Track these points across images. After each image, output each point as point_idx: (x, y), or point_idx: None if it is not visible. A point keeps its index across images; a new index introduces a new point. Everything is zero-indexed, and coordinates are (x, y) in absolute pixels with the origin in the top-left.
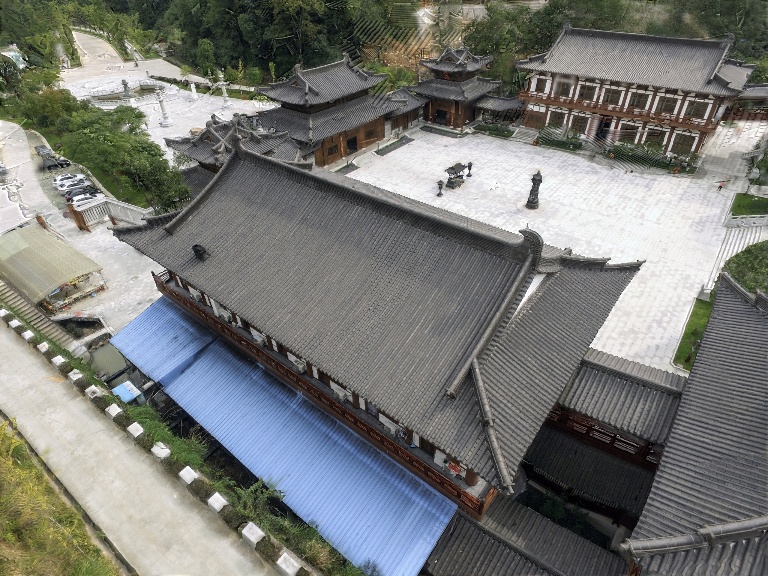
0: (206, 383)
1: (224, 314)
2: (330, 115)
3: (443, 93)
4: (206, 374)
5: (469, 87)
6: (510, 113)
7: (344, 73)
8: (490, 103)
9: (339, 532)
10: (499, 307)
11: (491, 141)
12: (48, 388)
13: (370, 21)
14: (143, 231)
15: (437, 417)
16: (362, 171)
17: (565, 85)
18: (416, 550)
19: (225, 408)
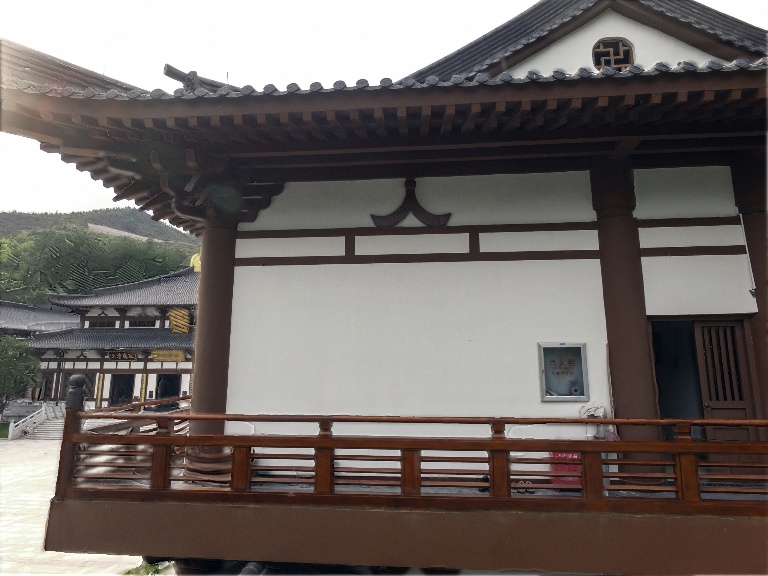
0: None
1: None
2: None
3: None
4: None
5: None
6: None
7: None
8: None
9: None
10: None
11: None
12: None
13: None
14: None
15: None
16: None
17: None
18: None
19: None
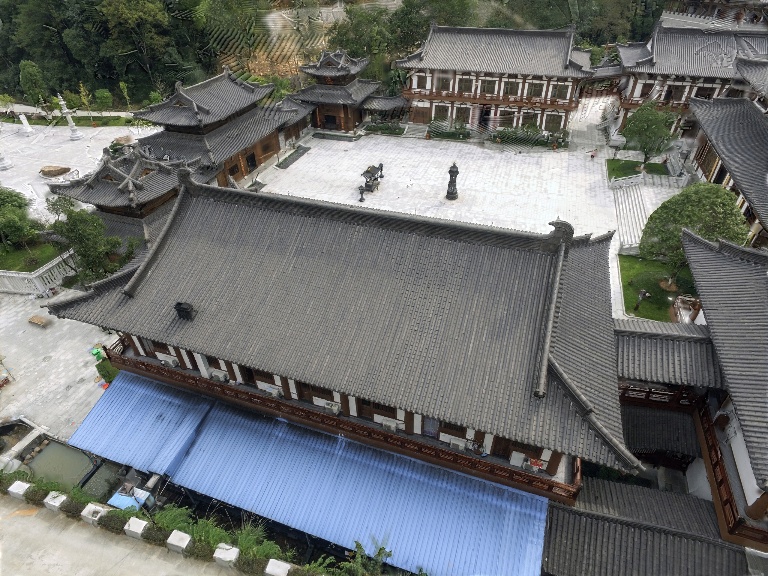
0: (224, 457)
1: (218, 374)
2: (224, 133)
3: (330, 98)
4: (219, 447)
5: (353, 90)
6: (396, 111)
7: (228, 87)
8: (375, 103)
9: (446, 567)
10: (551, 299)
11: (386, 140)
12: (19, 527)
13: (226, 30)
14: (89, 300)
15: (534, 420)
16: (271, 188)
17: (444, 80)
18: (528, 556)
19: (260, 478)
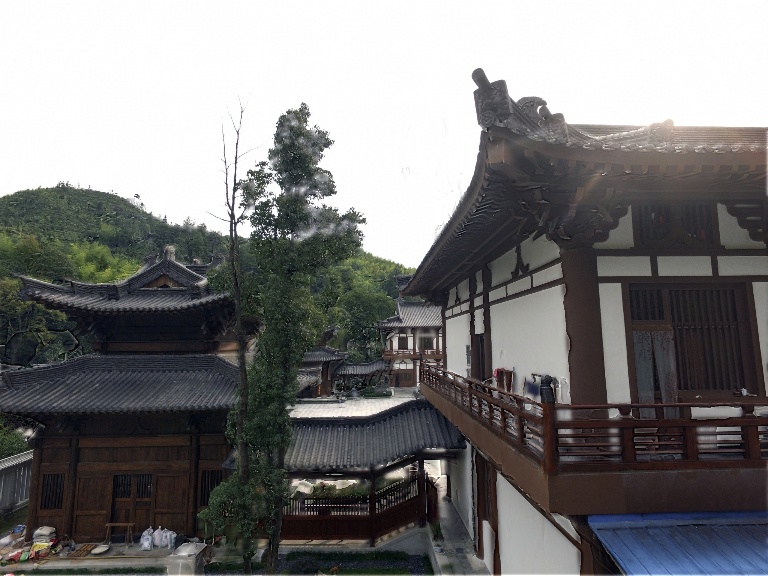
0: None
1: None
2: None
3: (307, 358)
4: None
5: None
6: (375, 376)
7: None
8: (350, 370)
9: None
10: None
11: (379, 400)
12: None
13: None
14: None
15: None
16: None
17: (426, 340)
18: None
19: None
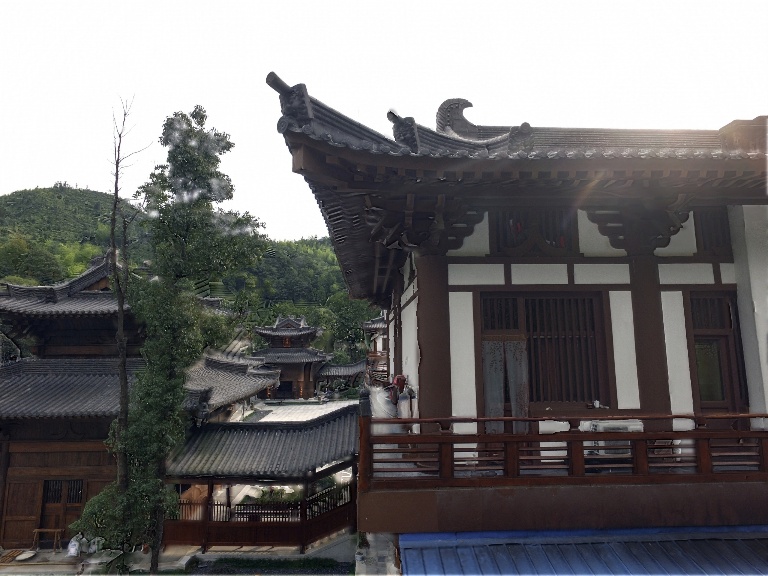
0: None
1: None
2: None
3: (289, 359)
4: None
5: None
6: (359, 378)
7: None
8: (334, 371)
9: None
10: None
11: None
12: None
13: None
14: None
15: None
16: None
17: None
18: None
19: None
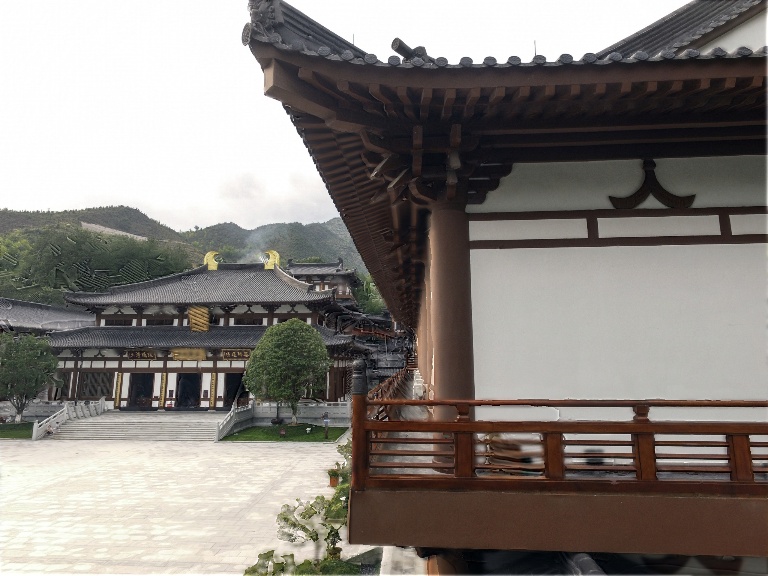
0: None
1: None
2: None
3: None
4: None
5: None
6: None
7: None
8: None
9: None
10: None
11: None
12: None
13: None
14: None
15: None
16: None
17: None
18: None
19: None
